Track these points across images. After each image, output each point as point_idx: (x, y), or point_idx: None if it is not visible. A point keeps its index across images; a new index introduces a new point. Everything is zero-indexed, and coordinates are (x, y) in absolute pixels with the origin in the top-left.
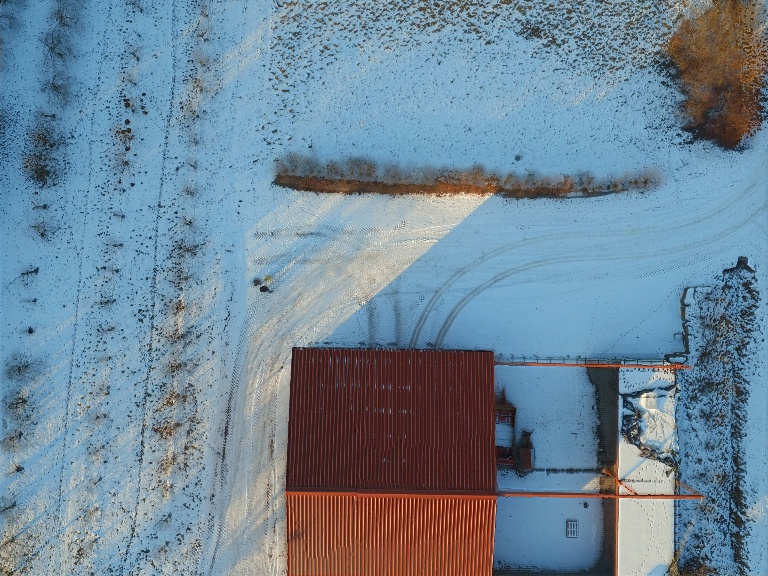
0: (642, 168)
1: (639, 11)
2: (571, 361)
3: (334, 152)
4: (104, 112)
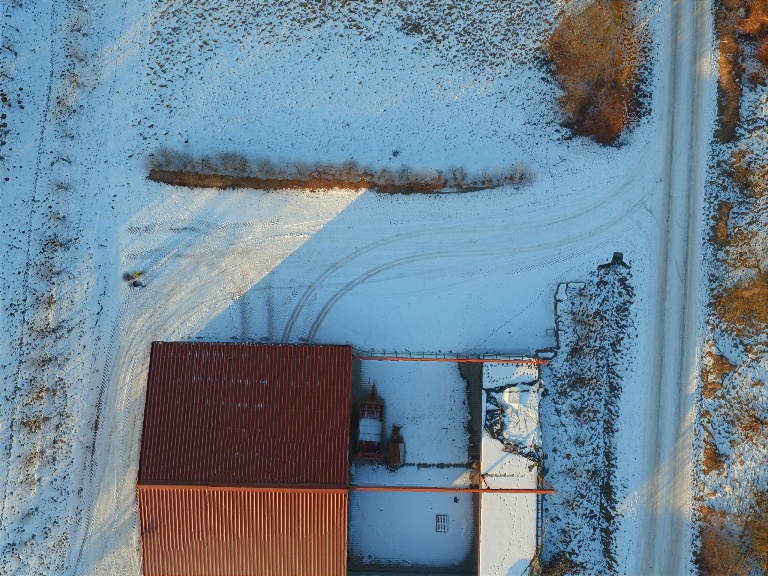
0: (519, 164)
1: (520, 7)
2: (430, 356)
3: (210, 147)
4: None
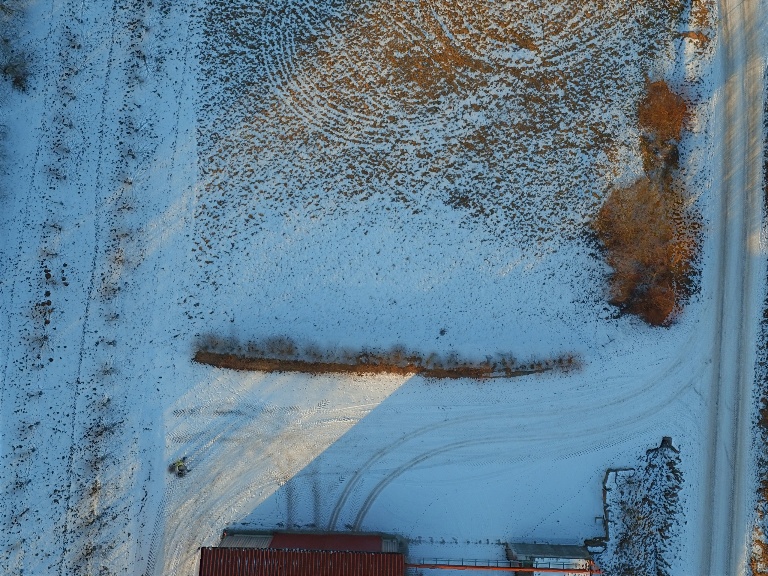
0: (568, 344)
1: (569, 180)
2: (483, 563)
3: (256, 326)
4: (24, 283)
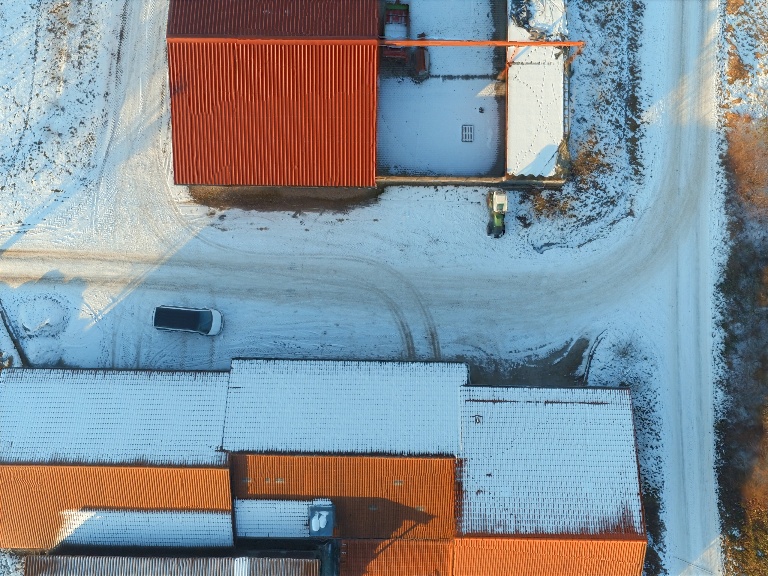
0: None
1: None
2: None
3: None
4: None
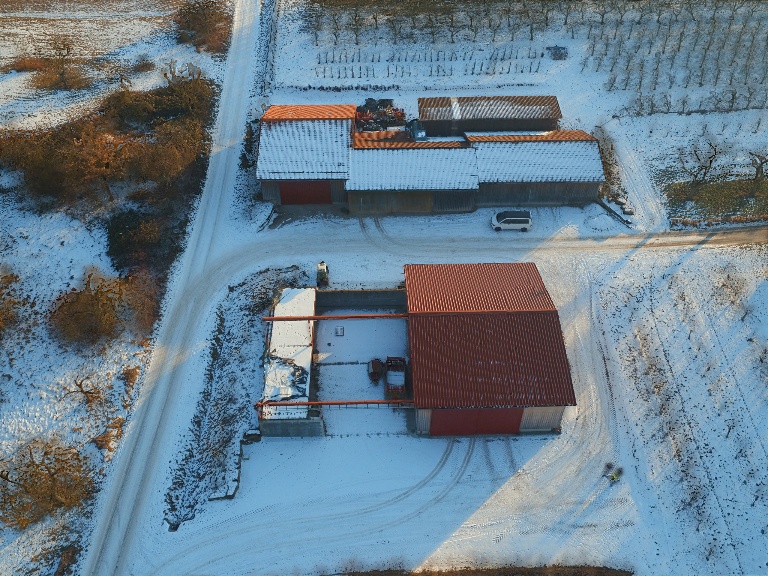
0: None
1: None
2: (351, 407)
3: None
4: None
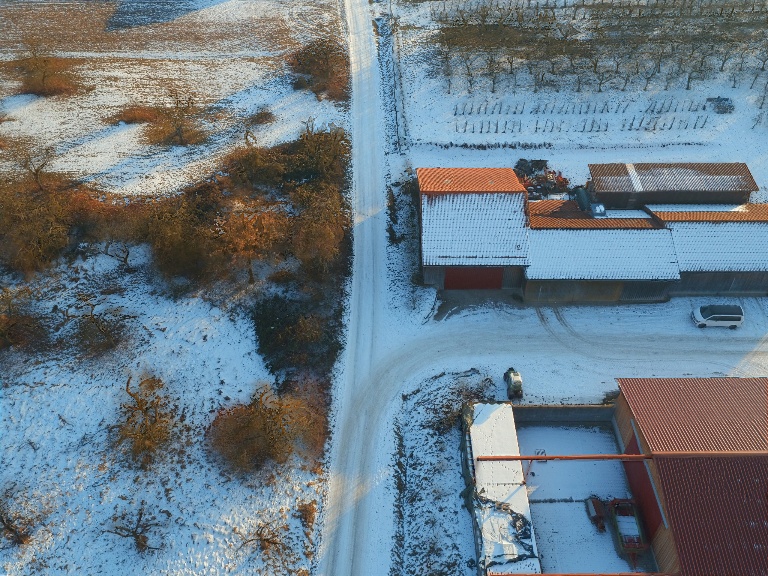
0: None
1: None
2: None
3: None
4: None
